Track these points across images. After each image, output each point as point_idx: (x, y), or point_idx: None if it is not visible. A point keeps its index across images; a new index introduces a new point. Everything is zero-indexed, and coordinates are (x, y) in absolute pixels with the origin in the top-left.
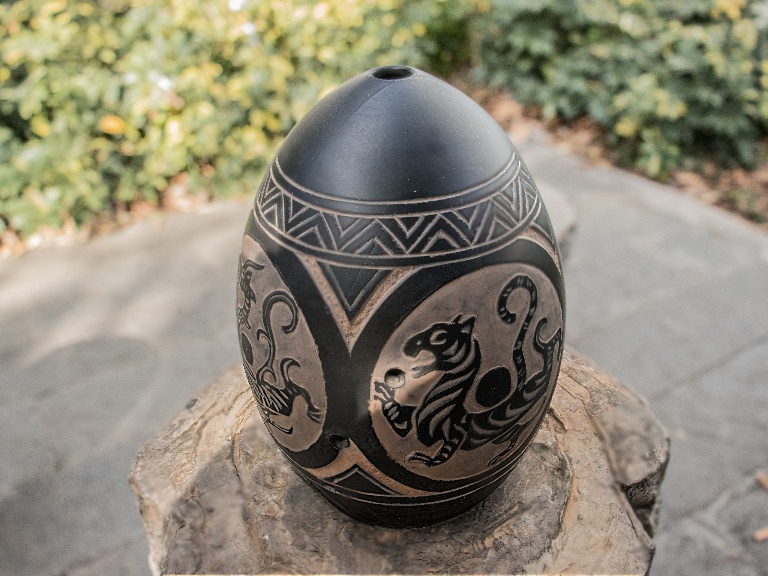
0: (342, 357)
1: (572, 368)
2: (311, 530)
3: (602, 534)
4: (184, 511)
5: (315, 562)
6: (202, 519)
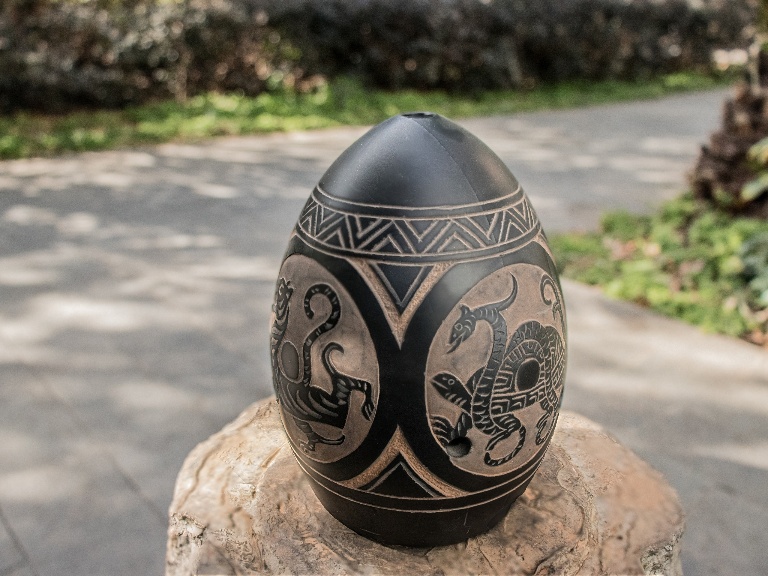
0: None
1: None
2: None
3: None
4: None
5: (289, 449)
6: None
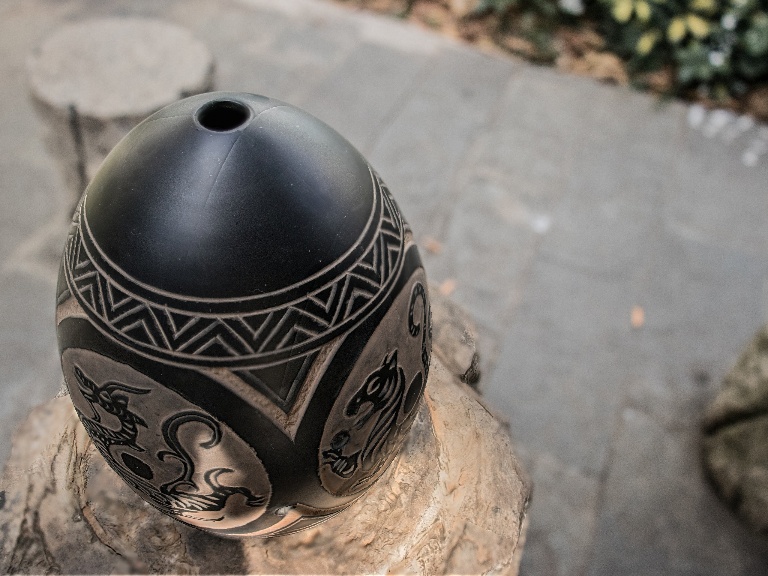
0: (285, 448)
1: None
2: (238, 570)
3: (469, 430)
4: None
5: None
6: None
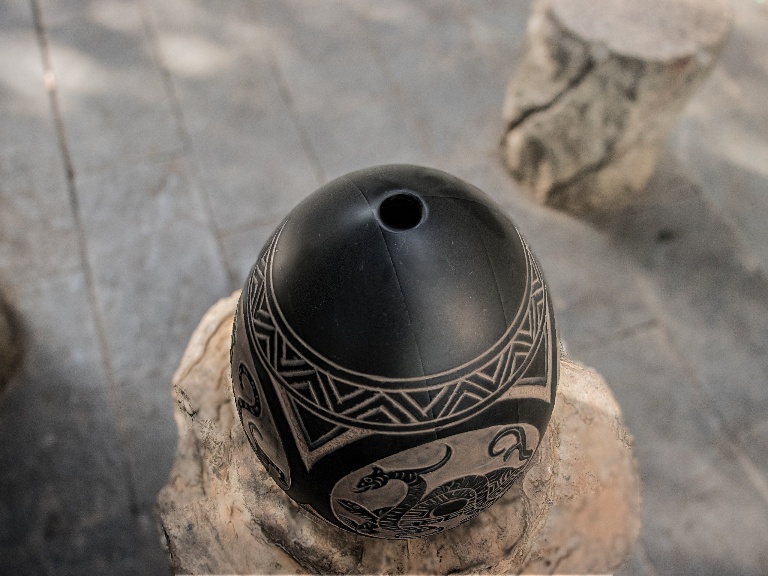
0: None
1: None
2: None
3: None
4: None
5: None
6: None
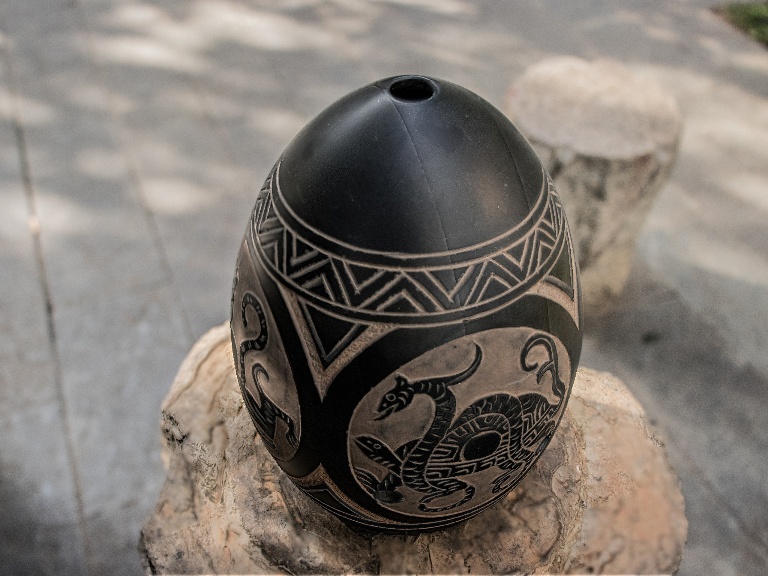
0: None
1: None
2: None
3: None
4: None
5: None
6: None
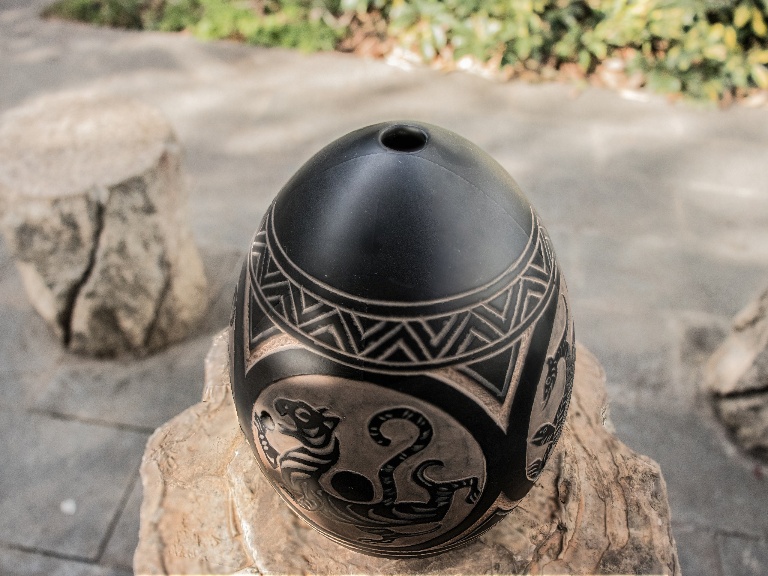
0: (242, 374)
1: (639, 505)
2: None
3: None
4: (215, 391)
5: (246, 499)
6: (217, 406)
